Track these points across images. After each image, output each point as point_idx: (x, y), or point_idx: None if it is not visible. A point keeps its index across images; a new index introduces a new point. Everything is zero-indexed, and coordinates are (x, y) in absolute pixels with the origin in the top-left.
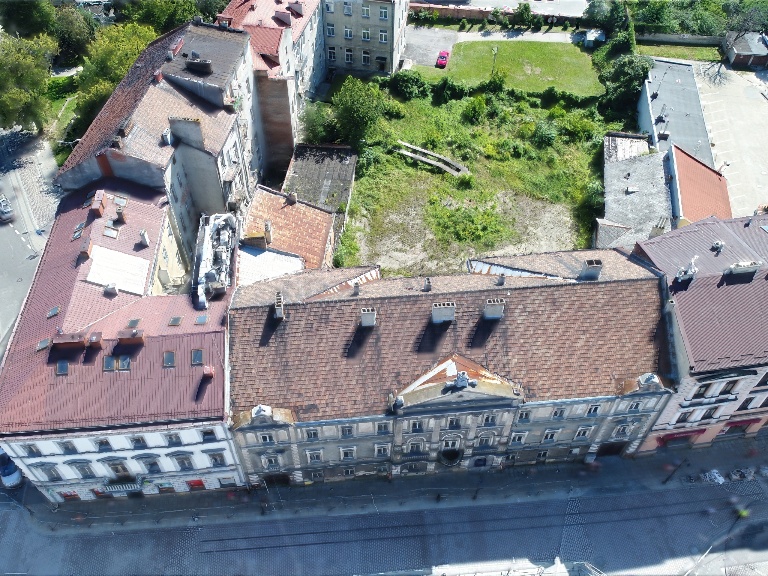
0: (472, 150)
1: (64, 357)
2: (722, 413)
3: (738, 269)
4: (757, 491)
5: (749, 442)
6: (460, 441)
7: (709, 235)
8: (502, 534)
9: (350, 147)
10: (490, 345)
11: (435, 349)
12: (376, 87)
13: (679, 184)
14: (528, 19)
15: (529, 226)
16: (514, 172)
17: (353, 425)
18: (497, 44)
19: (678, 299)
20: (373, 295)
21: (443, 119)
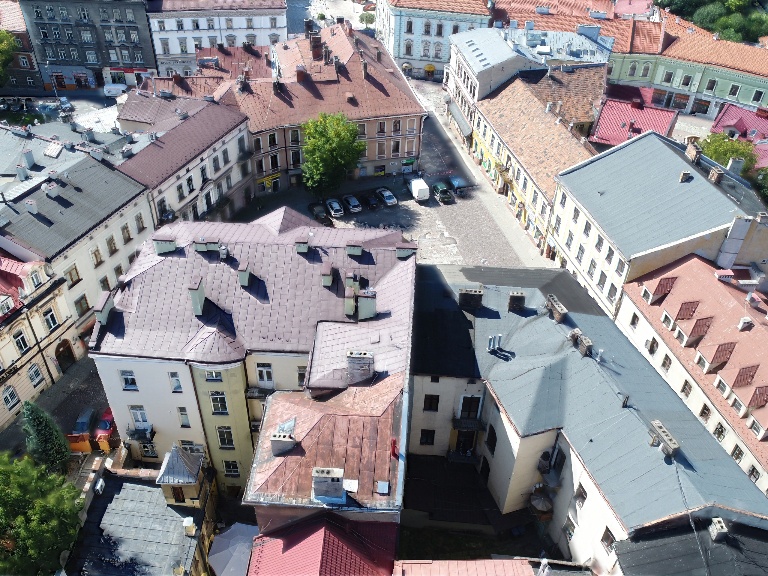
0: None
1: None
2: None
3: None
4: None
5: None
6: None
7: None
8: None
9: None
10: None
11: None
12: None
13: None
14: None
15: None
16: None
17: None
18: None
19: None
20: None
21: None
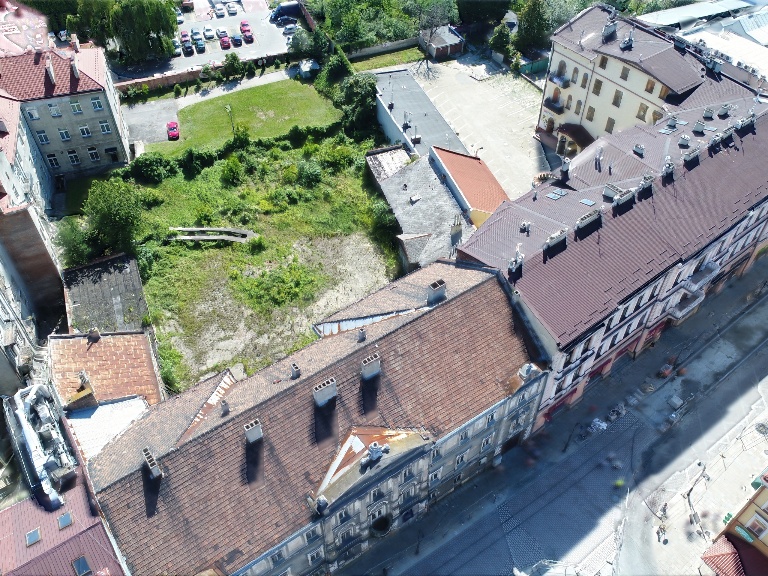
0: (248, 212)
1: None
2: (585, 369)
3: (553, 241)
4: (634, 421)
5: (608, 381)
6: (386, 507)
7: (512, 219)
8: (458, 574)
9: (124, 253)
10: (381, 403)
11: (332, 432)
12: (119, 181)
13: (454, 180)
14: (240, 68)
15: (337, 265)
16: (299, 219)
17: (282, 549)
18: (220, 100)
19: (520, 288)
20: (246, 406)
21: (204, 191)
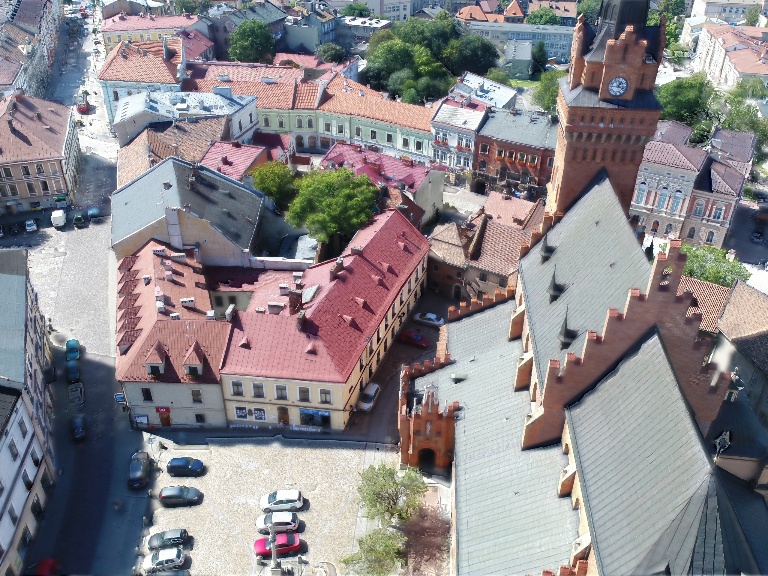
0: None
1: None
2: None
3: None
4: None
5: None
6: None
7: None
8: None
9: None
10: (16, 42)
11: (14, 46)
12: None
13: None
14: None
15: None
16: None
17: None
18: None
19: None
20: None
21: None
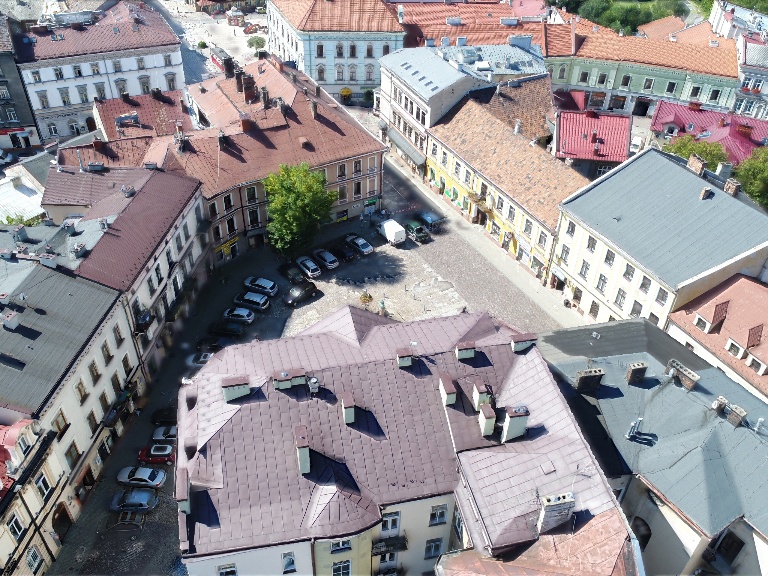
0: None
1: (142, 22)
2: None
3: None
4: None
5: None
6: None
7: None
8: None
9: None
10: None
11: None
12: None
13: None
14: None
15: None
16: None
17: None
18: None
19: None
20: None
21: None
